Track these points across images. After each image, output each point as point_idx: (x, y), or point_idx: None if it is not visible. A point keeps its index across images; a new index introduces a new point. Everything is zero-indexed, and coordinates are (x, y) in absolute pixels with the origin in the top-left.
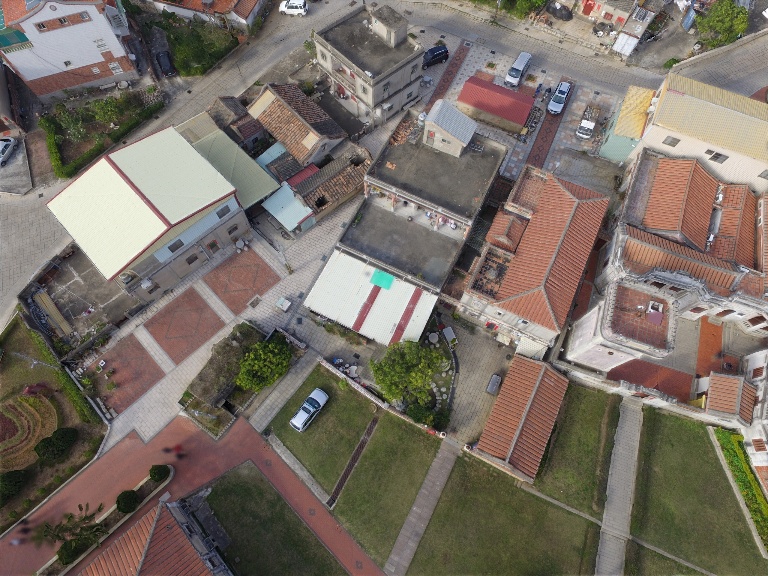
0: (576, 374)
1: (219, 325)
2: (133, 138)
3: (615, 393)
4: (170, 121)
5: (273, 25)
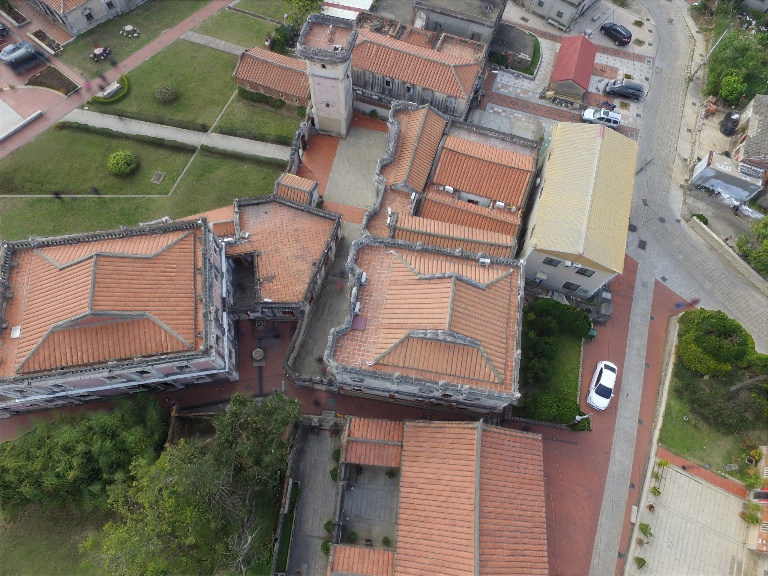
0: None
1: None
2: None
3: None
4: None
5: None
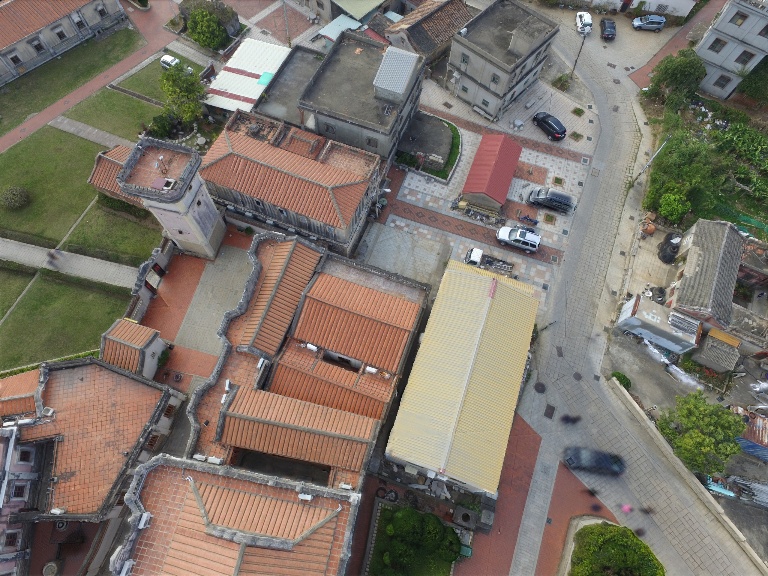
0: None
1: (247, 17)
2: None
3: None
4: None
5: (559, 14)
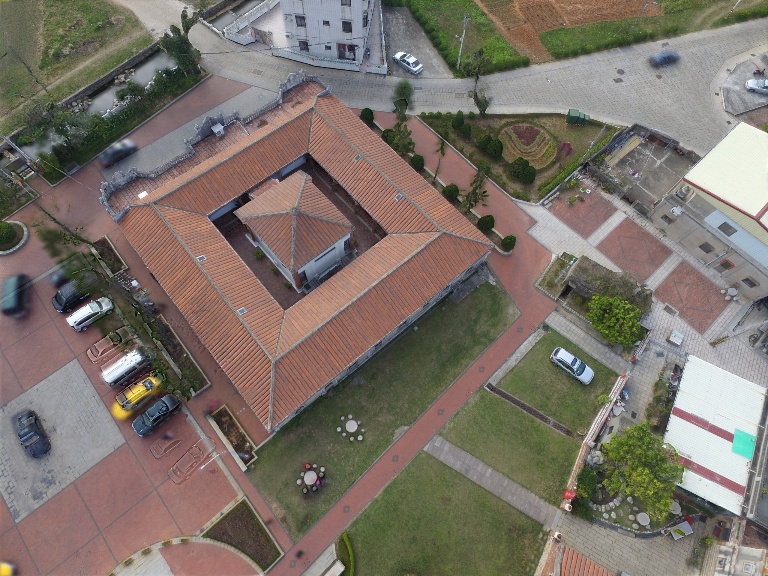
0: None
1: (640, 279)
2: None
3: None
4: None
5: None
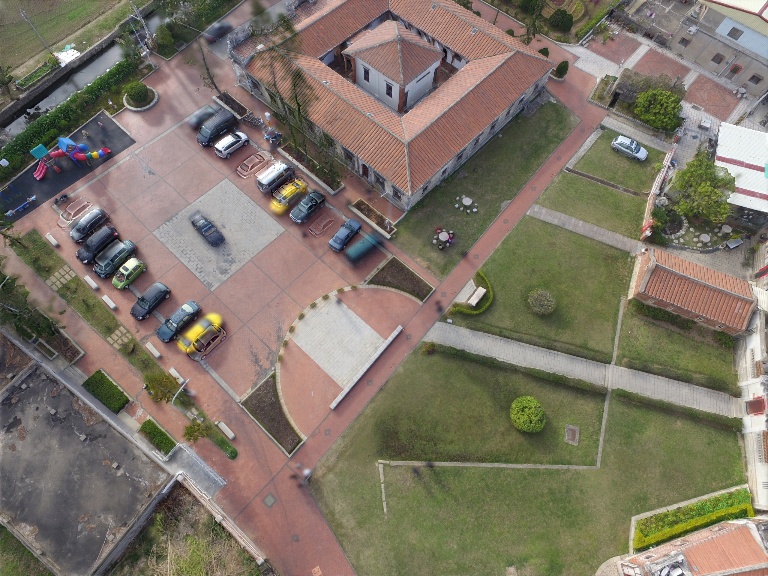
0: (752, 341)
1: None
2: None
3: (742, 388)
4: None
5: None
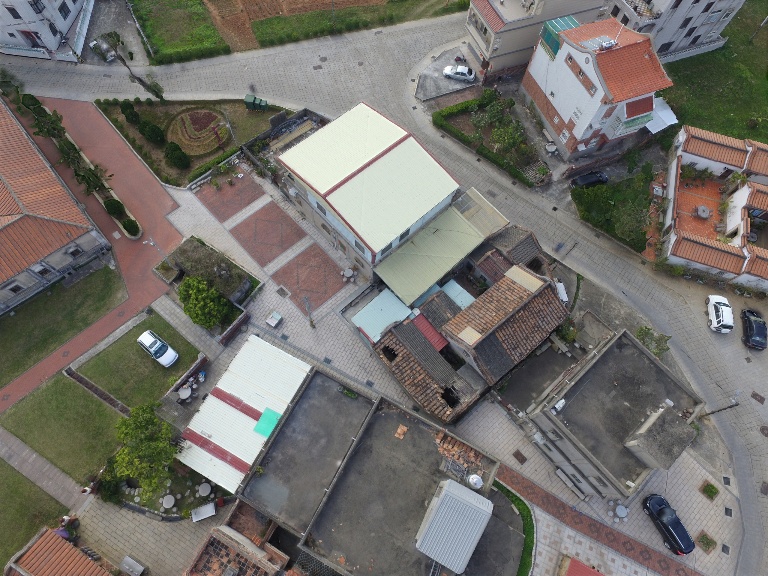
0: None
1: (263, 262)
2: (485, 166)
3: None
4: (511, 195)
5: (683, 290)
